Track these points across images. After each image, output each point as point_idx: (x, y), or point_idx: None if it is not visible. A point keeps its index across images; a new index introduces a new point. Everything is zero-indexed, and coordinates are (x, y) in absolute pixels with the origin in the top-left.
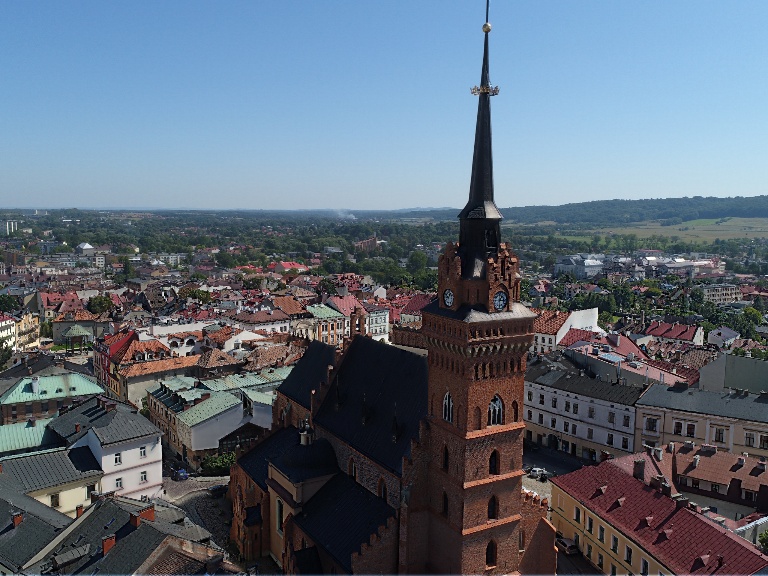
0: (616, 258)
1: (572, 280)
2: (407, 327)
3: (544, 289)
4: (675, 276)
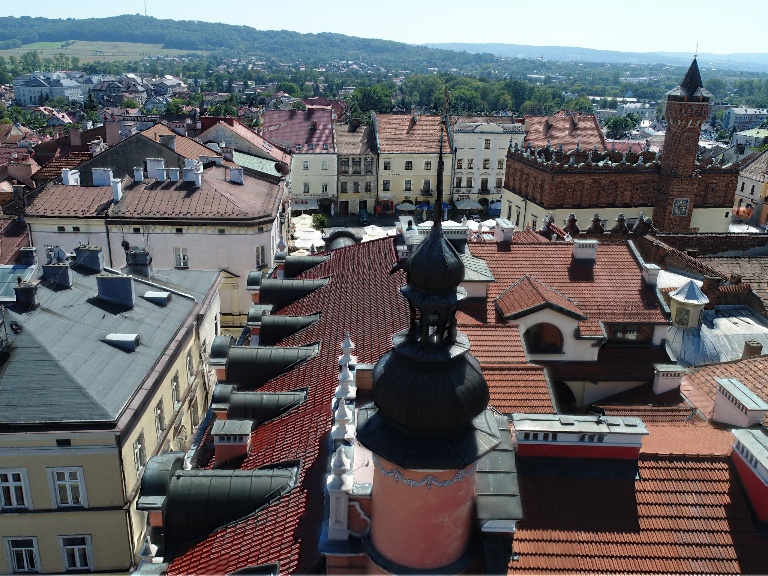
0: (106, 75)
1: (95, 104)
2: (591, 164)
3: (69, 119)
4: (200, 94)
